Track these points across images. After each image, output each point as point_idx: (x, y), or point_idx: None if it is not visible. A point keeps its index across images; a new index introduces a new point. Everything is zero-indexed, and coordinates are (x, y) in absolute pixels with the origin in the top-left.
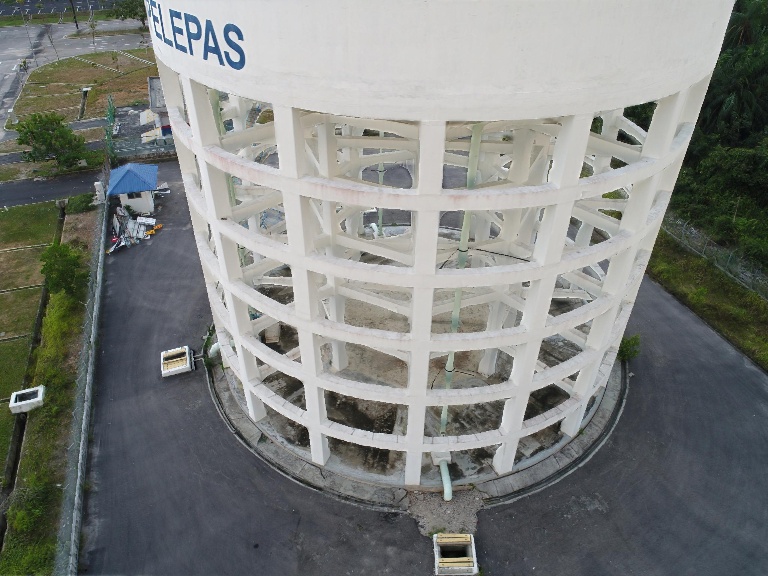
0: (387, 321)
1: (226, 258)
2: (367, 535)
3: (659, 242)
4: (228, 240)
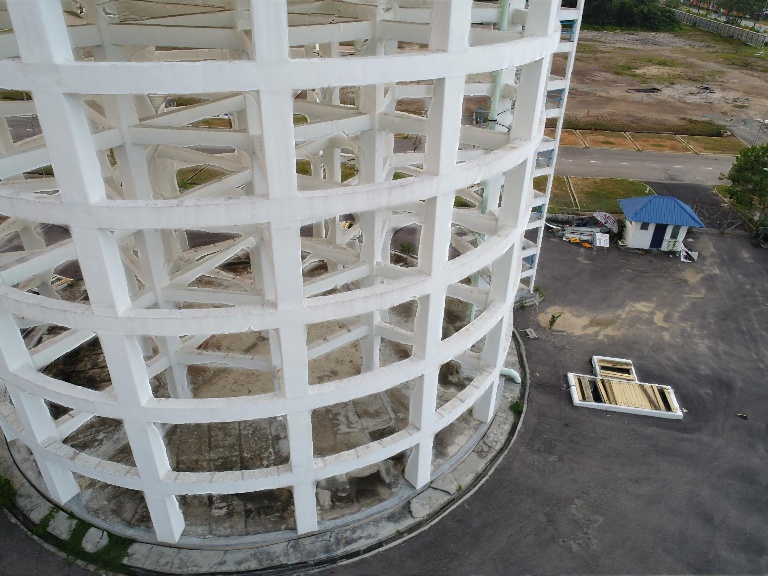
0: None
1: None
2: None
3: None
4: None
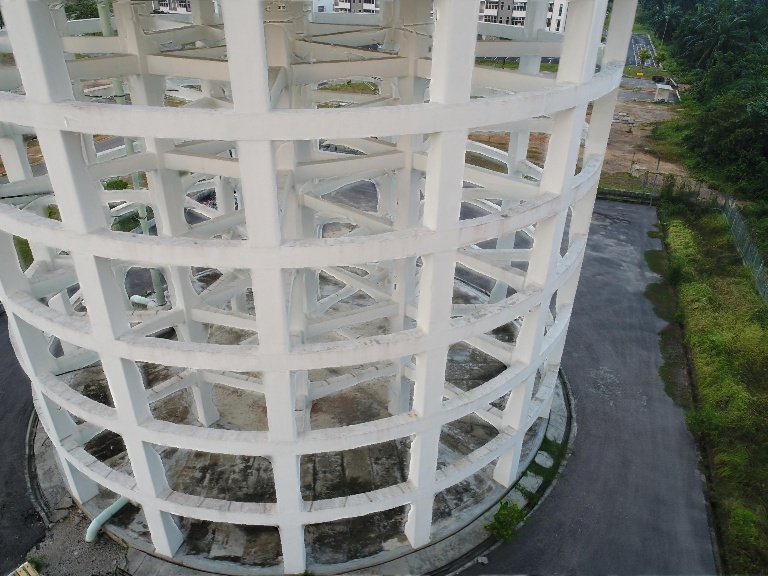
0: None
1: (6, 167)
2: None
3: None
4: (7, 148)
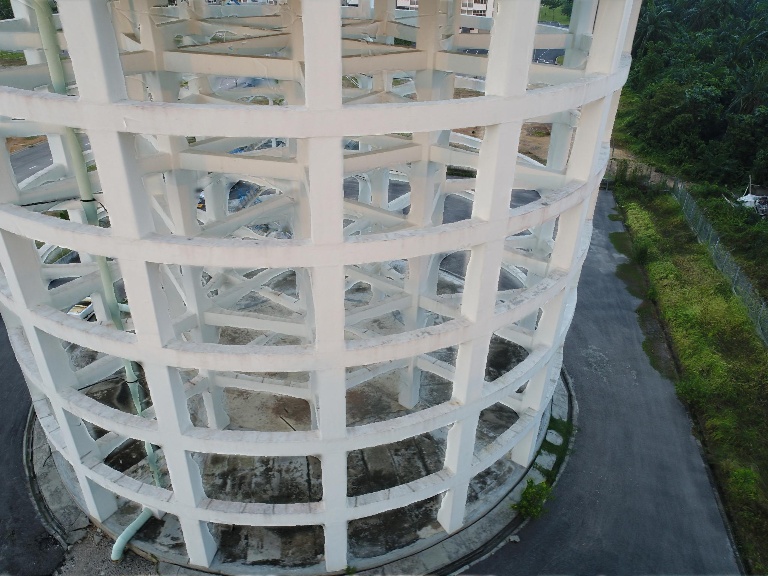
0: (283, 344)
1: None
2: (6, 546)
3: (764, 392)
4: None
